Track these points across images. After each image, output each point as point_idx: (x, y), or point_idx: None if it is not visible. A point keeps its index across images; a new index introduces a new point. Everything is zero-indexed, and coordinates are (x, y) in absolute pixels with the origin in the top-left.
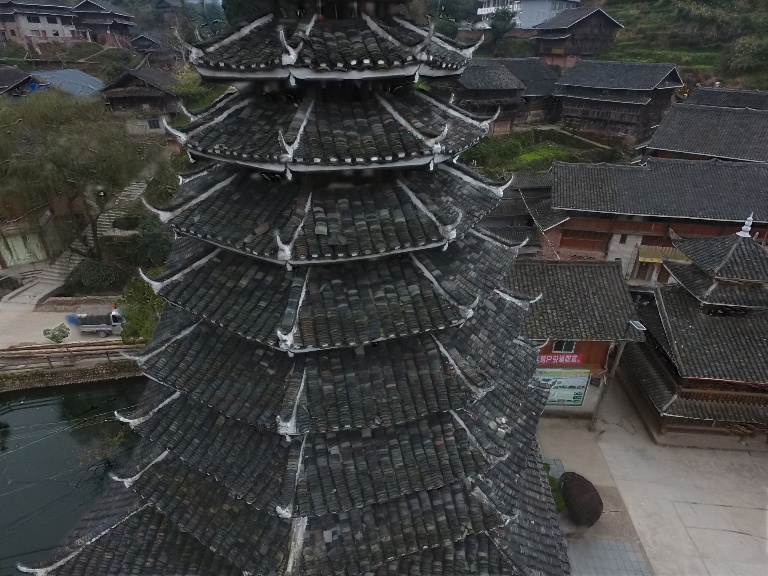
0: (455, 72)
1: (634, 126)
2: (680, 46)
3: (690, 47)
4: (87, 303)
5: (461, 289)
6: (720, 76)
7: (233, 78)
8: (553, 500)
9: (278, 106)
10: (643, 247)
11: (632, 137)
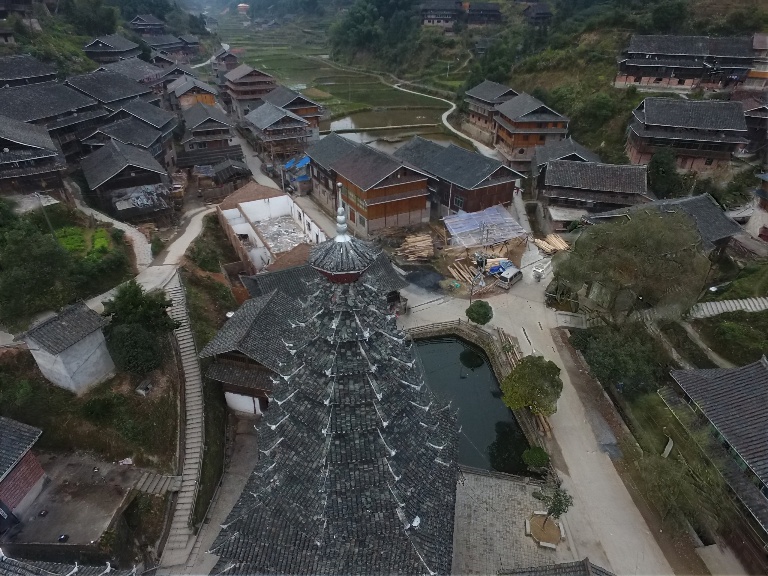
0: None
1: None
2: None
3: None
4: (569, 348)
5: (285, 426)
6: None
7: None
8: (295, 574)
9: None
10: None
11: None
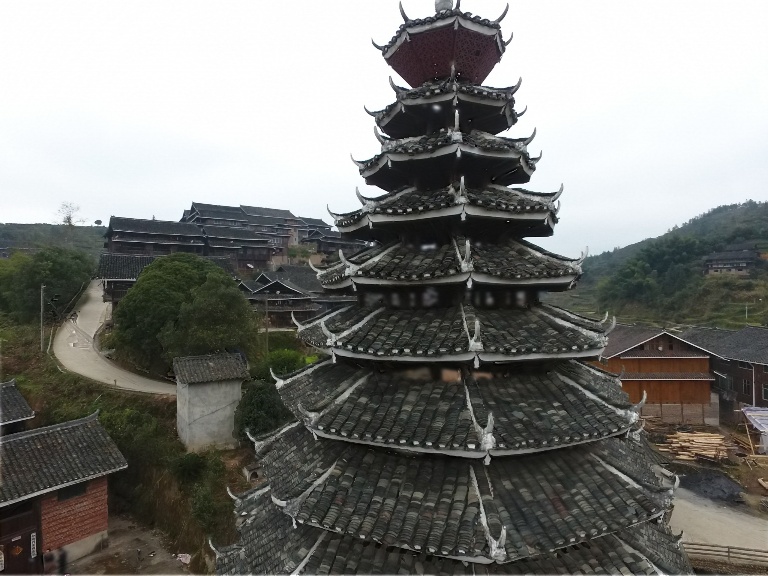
0: (364, 224)
1: None
2: None
3: None
4: None
5: (297, 383)
6: None
7: None
8: None
9: None
10: None
11: None
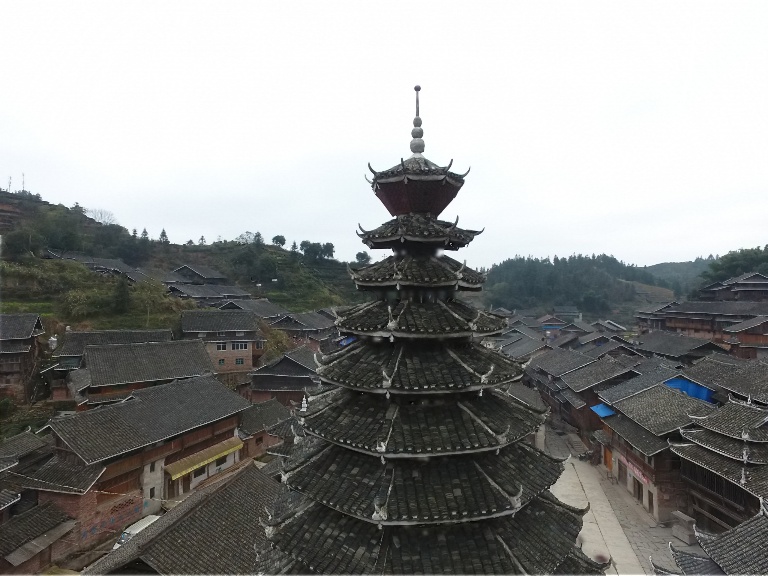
0: None
1: (16, 374)
2: (9, 298)
3: (21, 299)
4: None
5: None
6: (65, 321)
7: (484, 336)
8: None
9: (464, 351)
10: (168, 467)
11: (17, 386)
